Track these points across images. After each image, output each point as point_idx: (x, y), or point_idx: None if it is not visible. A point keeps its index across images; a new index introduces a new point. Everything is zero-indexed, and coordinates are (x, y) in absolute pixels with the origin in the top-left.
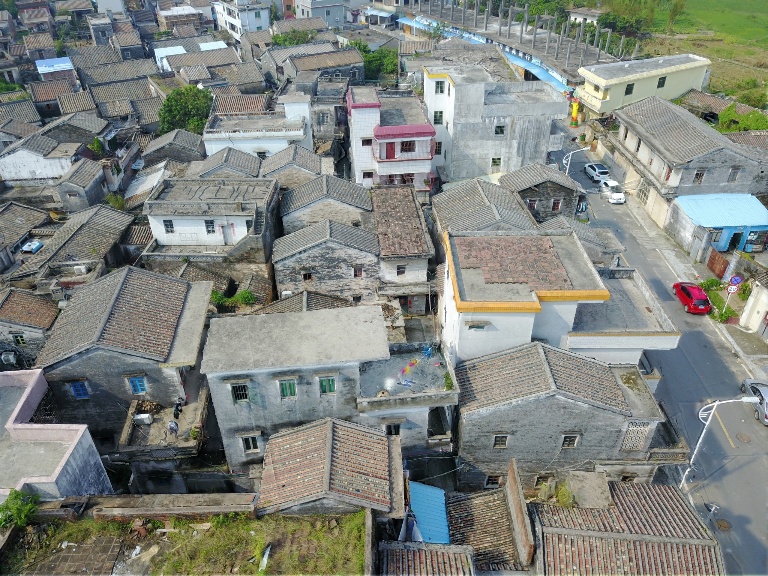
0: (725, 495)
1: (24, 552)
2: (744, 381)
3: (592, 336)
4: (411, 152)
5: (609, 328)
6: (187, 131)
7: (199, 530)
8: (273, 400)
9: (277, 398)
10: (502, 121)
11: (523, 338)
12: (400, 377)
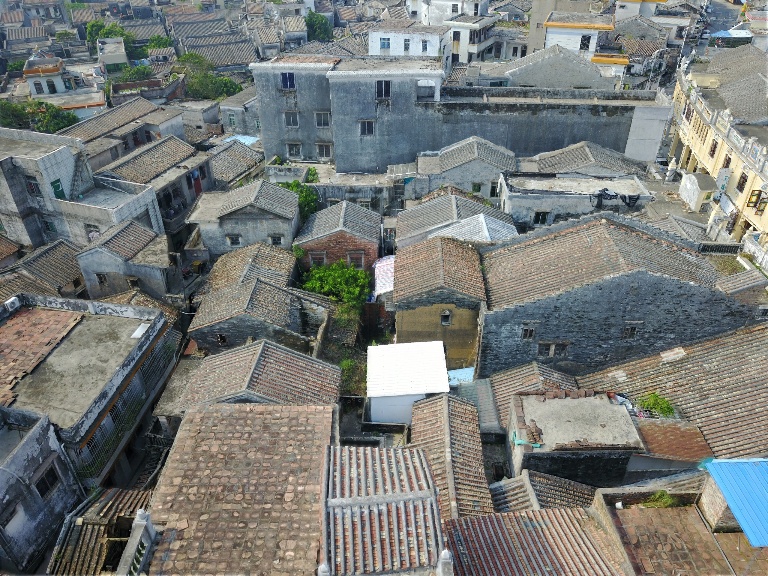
0: None
1: None
2: None
3: (660, 17)
4: None
5: None
6: None
7: None
8: None
9: None
10: None
11: (636, 13)
12: None
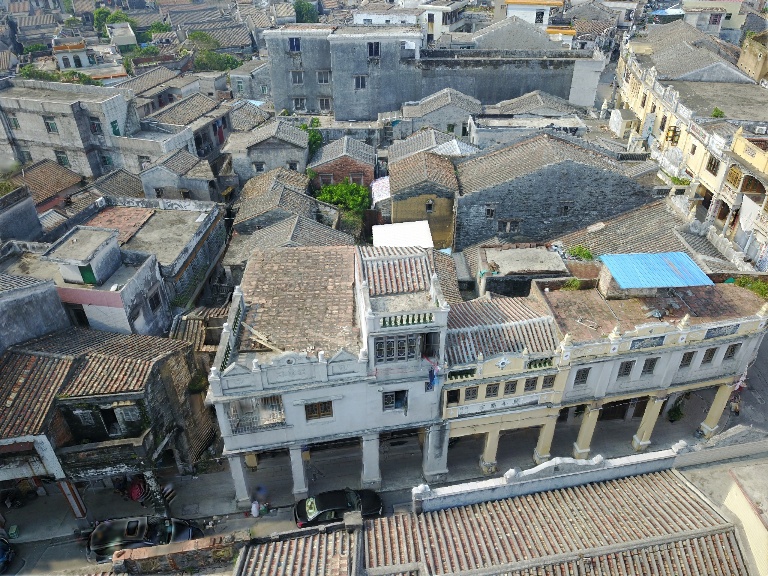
0: None
1: None
2: None
3: (611, 2)
4: None
5: None
6: None
7: None
8: None
9: None
10: None
11: None
12: None
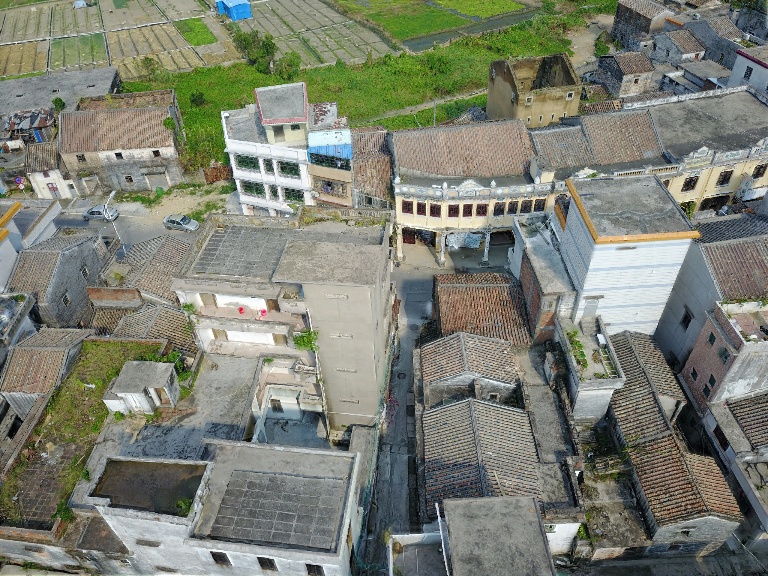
0: None
1: (7, 520)
2: (83, 216)
3: (32, 231)
4: None
5: (28, 226)
6: None
7: (49, 422)
8: None
9: None
10: None
11: (13, 255)
12: (0, 315)
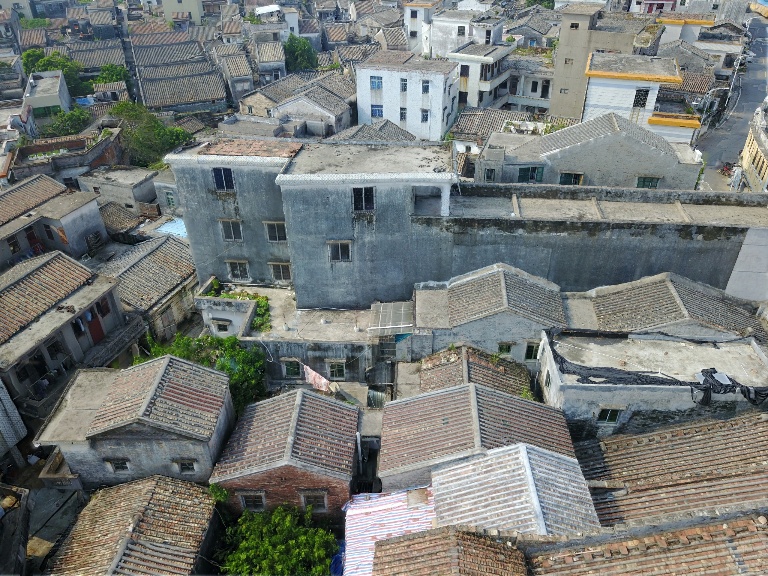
0: None
1: None
2: None
3: (705, 43)
4: (661, 9)
5: None
6: (542, 6)
7: None
8: None
9: None
10: (718, 1)
11: (676, 38)
12: None
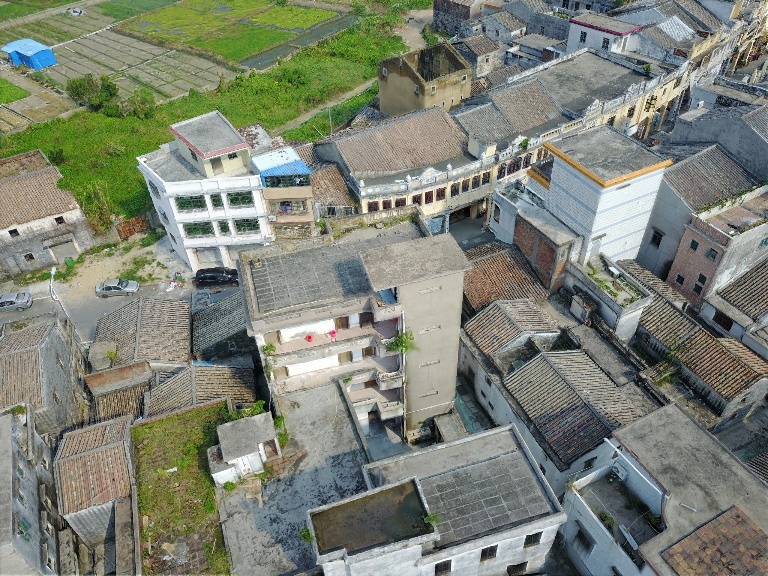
0: (83, 328)
1: None
2: None
3: None
4: None
5: None
6: None
7: (149, 523)
8: (26, 515)
9: (25, 510)
10: None
11: None
12: None
